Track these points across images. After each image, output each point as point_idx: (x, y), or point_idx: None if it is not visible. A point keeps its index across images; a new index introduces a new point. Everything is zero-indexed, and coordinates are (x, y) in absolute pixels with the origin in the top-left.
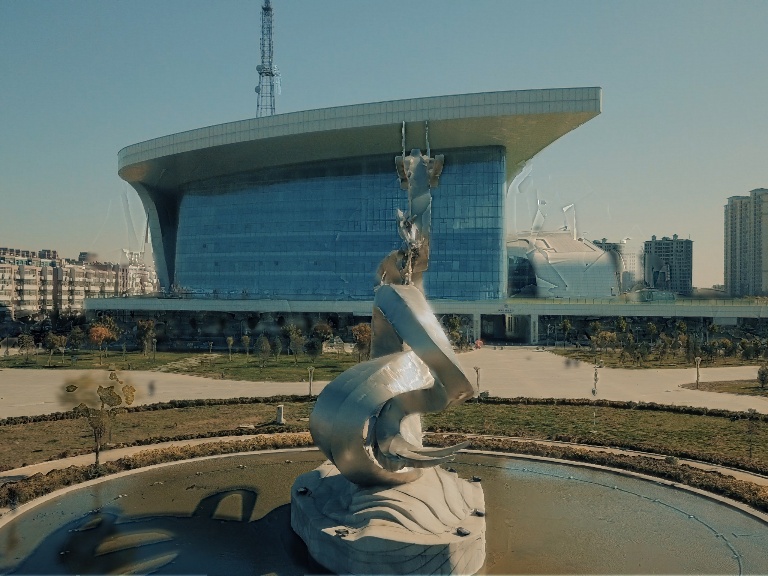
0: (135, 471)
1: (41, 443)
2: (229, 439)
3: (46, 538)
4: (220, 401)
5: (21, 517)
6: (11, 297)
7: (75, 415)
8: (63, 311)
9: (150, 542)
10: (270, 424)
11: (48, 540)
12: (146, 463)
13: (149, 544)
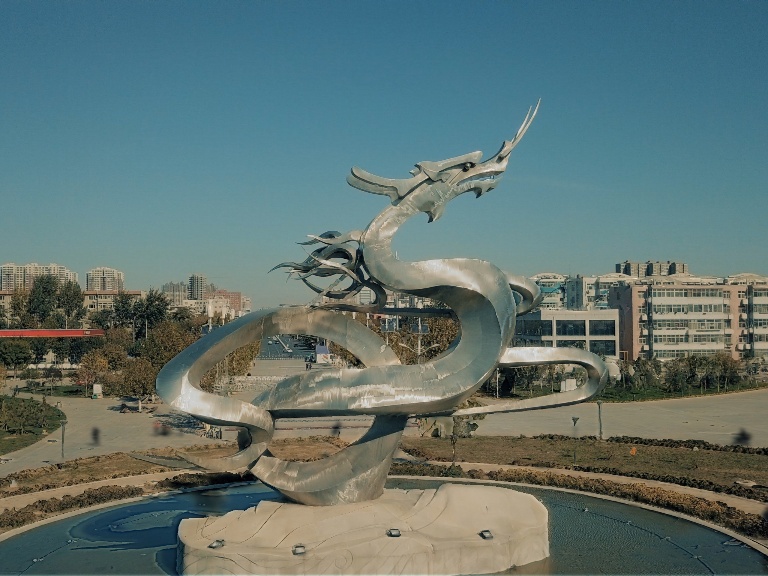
0: (475, 480)
1: (557, 455)
2: (662, 485)
3: None
4: None
5: None
6: None
7: (676, 444)
8: None
9: None
10: None
11: None
12: (504, 478)
13: None
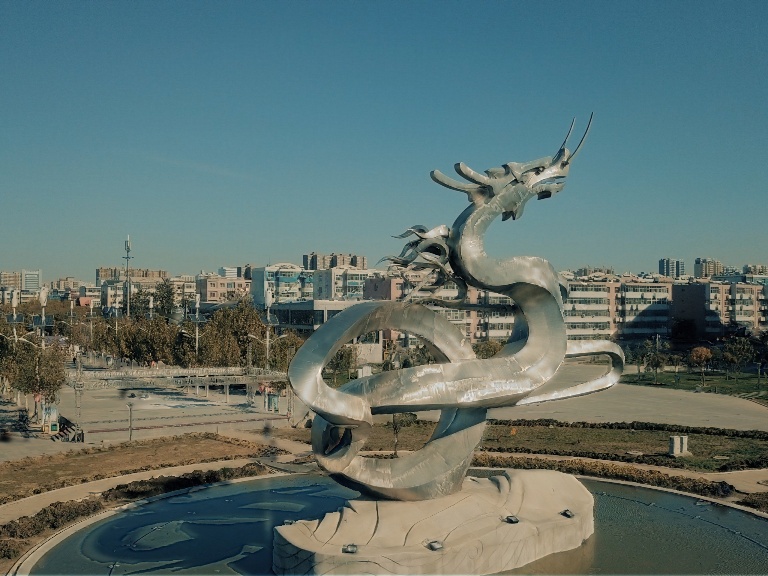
0: None
1: None
2: None
3: (252, 492)
4: (682, 428)
5: (279, 478)
6: (730, 317)
7: (532, 423)
8: (751, 332)
9: (283, 509)
10: (660, 455)
11: (252, 493)
12: None
13: (279, 510)
